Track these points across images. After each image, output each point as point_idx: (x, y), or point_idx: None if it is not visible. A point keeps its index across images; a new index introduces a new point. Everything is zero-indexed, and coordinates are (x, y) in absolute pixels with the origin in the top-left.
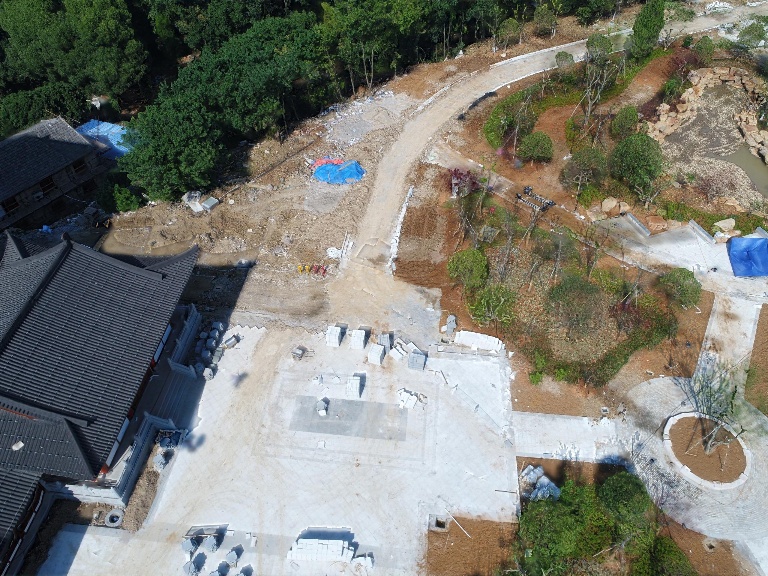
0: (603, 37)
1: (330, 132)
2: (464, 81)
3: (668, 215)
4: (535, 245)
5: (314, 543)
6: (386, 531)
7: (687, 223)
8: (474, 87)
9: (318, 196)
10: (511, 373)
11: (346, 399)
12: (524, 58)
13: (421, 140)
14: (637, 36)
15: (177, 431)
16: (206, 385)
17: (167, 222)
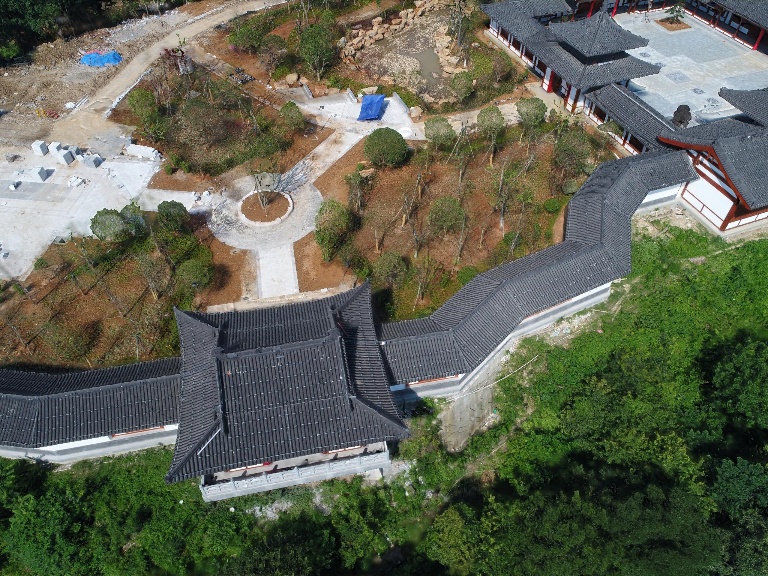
0: None
1: (112, 36)
2: (238, 4)
3: (331, 84)
4: (220, 101)
5: None
6: (24, 243)
7: (346, 91)
8: (243, 8)
9: (77, 73)
10: (157, 169)
11: (34, 182)
12: None
13: None
14: None
15: None
16: None
17: None
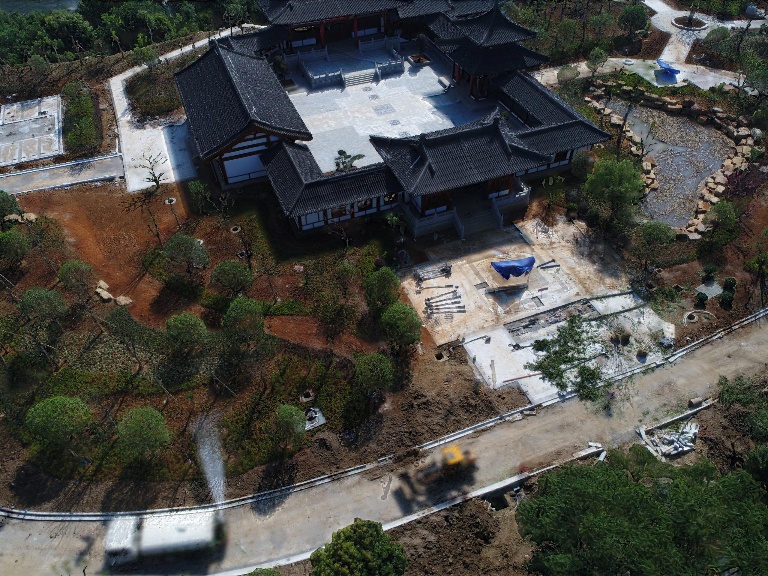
0: None
1: None
2: None
3: None
4: None
5: None
6: None
7: None
8: None
9: None
10: None
11: None
12: None
13: None
14: None
15: None
16: None
17: None
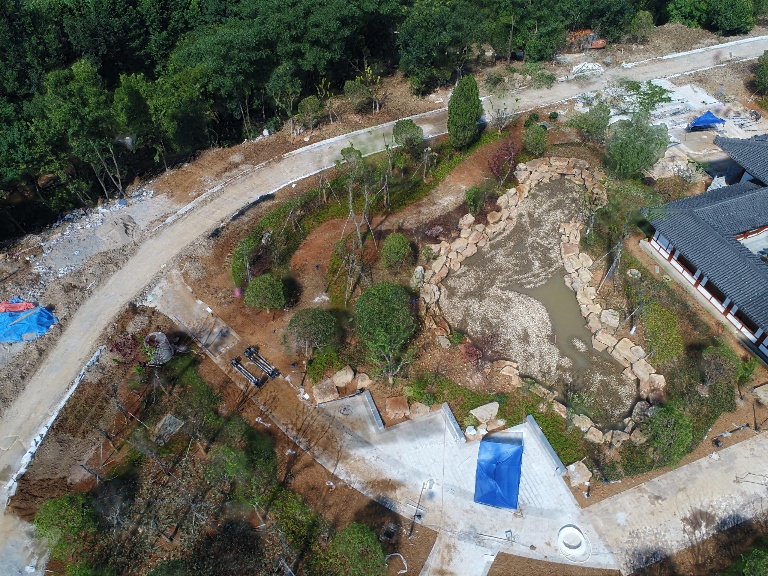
0: (410, 124)
1: (45, 255)
2: (244, 177)
3: (414, 396)
4: None
5: None
6: None
7: (440, 406)
8: (253, 186)
9: None
10: None
11: None
12: (331, 143)
13: (151, 269)
14: (450, 123)
15: None
16: None
17: None
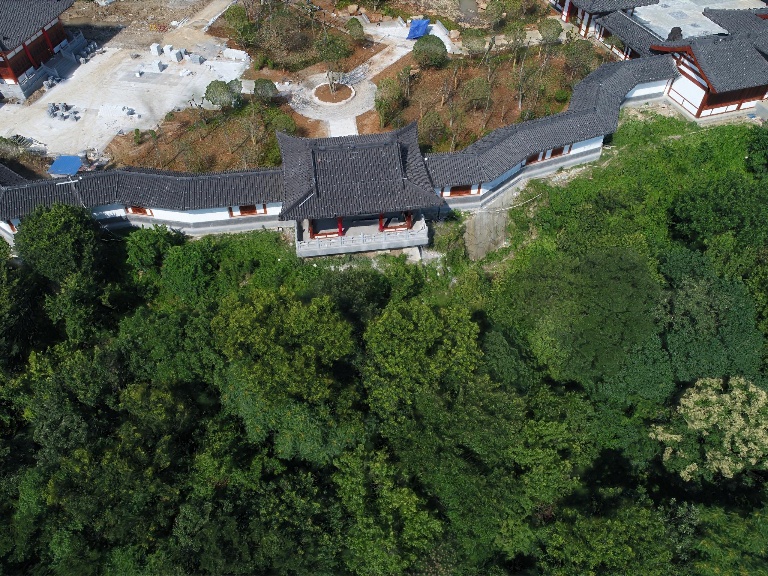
0: None
1: None
2: None
3: (385, 13)
4: None
5: (111, 105)
6: (151, 110)
7: (397, 19)
8: None
9: (178, 1)
10: (248, 67)
11: (153, 72)
12: None
13: None
14: None
15: (60, 79)
16: (81, 66)
17: (82, 8)
